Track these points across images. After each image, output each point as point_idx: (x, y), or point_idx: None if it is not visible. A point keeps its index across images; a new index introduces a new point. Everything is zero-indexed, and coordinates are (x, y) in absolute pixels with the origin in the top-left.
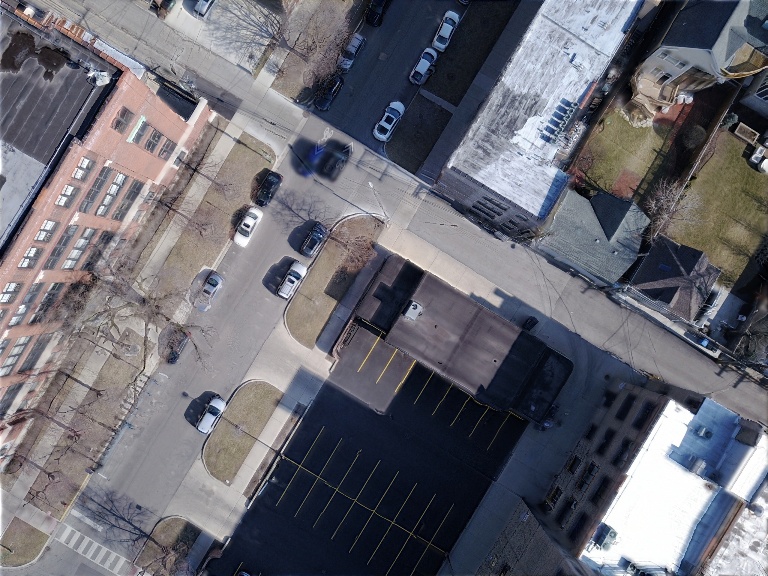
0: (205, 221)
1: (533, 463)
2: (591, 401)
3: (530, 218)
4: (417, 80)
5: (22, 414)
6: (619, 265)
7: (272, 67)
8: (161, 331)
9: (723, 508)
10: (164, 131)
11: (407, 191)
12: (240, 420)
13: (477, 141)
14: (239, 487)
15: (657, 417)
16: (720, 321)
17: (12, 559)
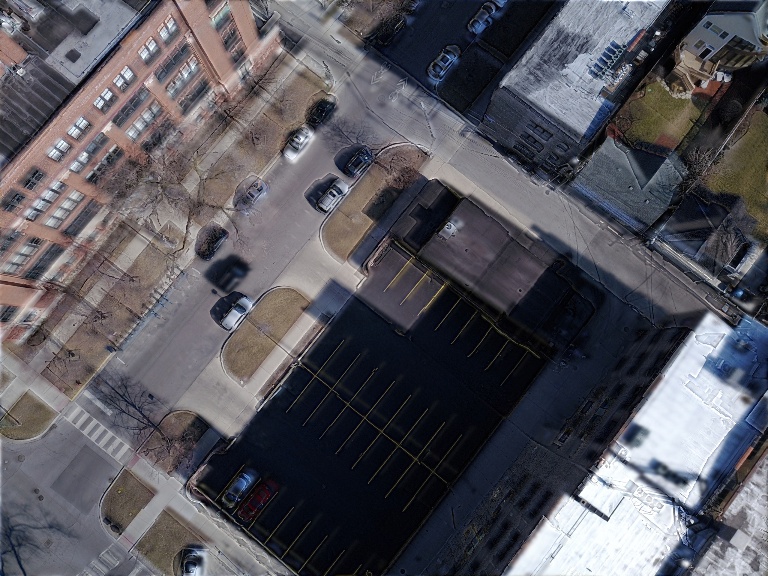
0: (259, 131)
1: (545, 404)
2: (609, 349)
3: (571, 146)
4: (475, 28)
5: (56, 285)
6: (649, 215)
7: (342, 1)
8: (201, 228)
9: (735, 445)
10: (240, 26)
11: (453, 128)
12: (263, 323)
13: (529, 68)
14: (252, 389)
15: (677, 344)
16: (742, 289)
17: (18, 431)
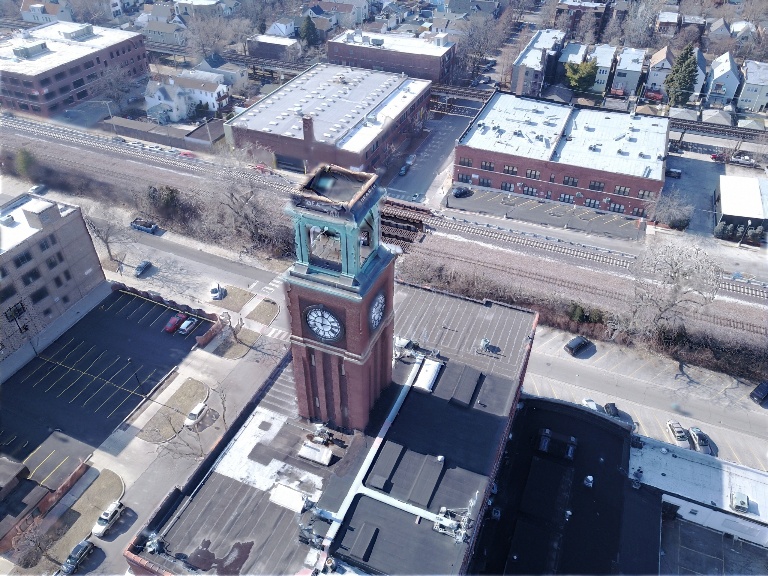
0: None
1: None
2: None
3: None
4: None
5: None
6: None
7: None
8: None
9: None
10: None
11: None
12: (174, 416)
13: None
14: (182, 377)
15: None
16: None
17: None
